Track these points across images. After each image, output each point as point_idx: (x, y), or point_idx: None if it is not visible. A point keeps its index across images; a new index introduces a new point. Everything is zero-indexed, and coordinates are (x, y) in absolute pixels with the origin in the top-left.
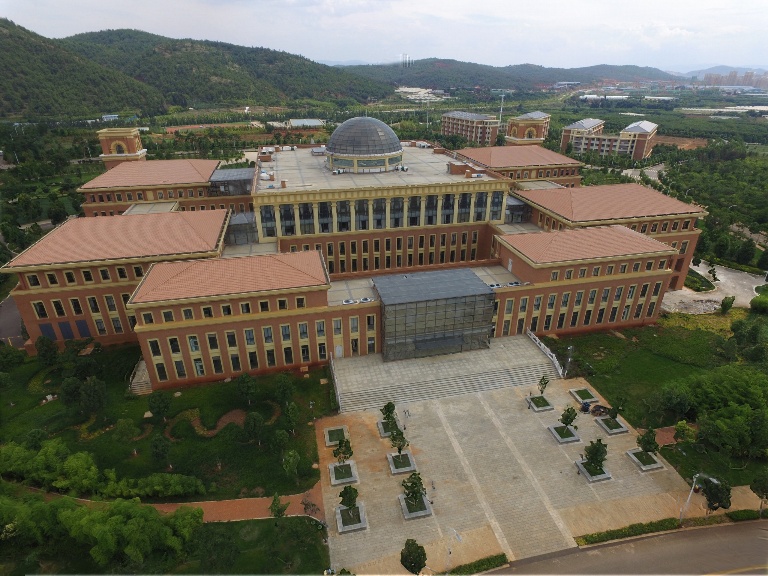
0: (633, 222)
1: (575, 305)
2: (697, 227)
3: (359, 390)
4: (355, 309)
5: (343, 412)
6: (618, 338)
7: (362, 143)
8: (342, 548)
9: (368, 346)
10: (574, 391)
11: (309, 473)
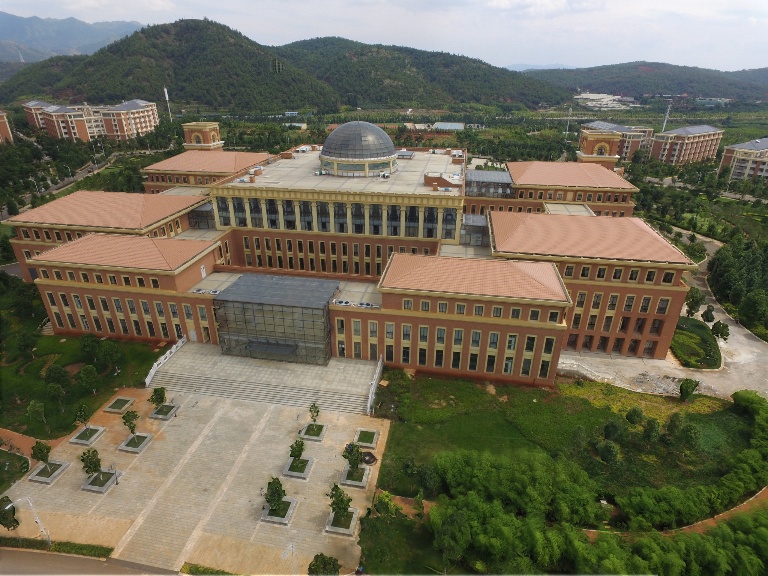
0: (581, 262)
1: (438, 342)
2: (766, 287)
3: (174, 372)
4: (200, 299)
5: (149, 387)
6: (484, 392)
7: (343, 147)
8: (17, 491)
9: (219, 336)
10: (360, 430)
11: (66, 427)
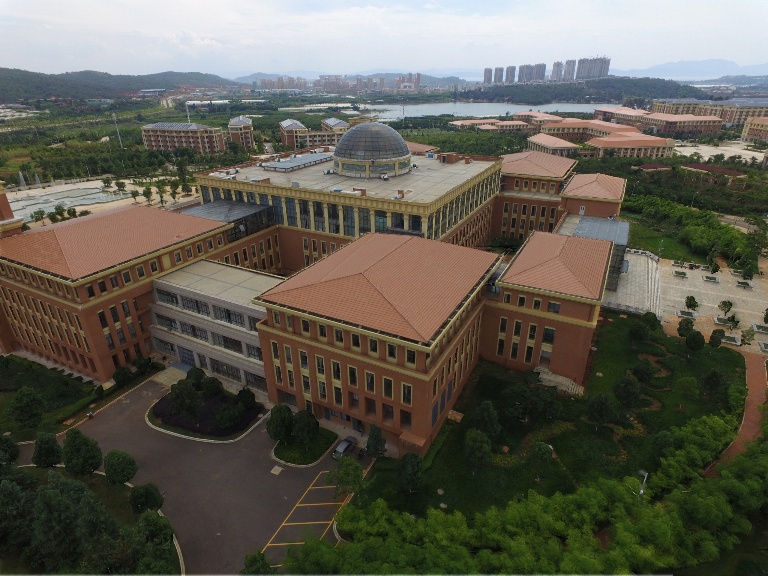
0: None
1: None
2: None
3: (646, 308)
4: None
5: (661, 323)
6: None
7: (398, 146)
8: None
9: None
10: None
11: (726, 349)
